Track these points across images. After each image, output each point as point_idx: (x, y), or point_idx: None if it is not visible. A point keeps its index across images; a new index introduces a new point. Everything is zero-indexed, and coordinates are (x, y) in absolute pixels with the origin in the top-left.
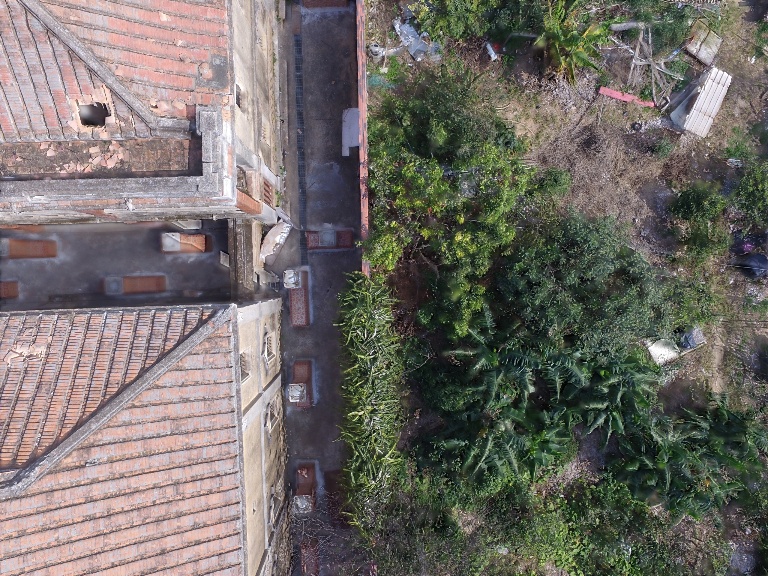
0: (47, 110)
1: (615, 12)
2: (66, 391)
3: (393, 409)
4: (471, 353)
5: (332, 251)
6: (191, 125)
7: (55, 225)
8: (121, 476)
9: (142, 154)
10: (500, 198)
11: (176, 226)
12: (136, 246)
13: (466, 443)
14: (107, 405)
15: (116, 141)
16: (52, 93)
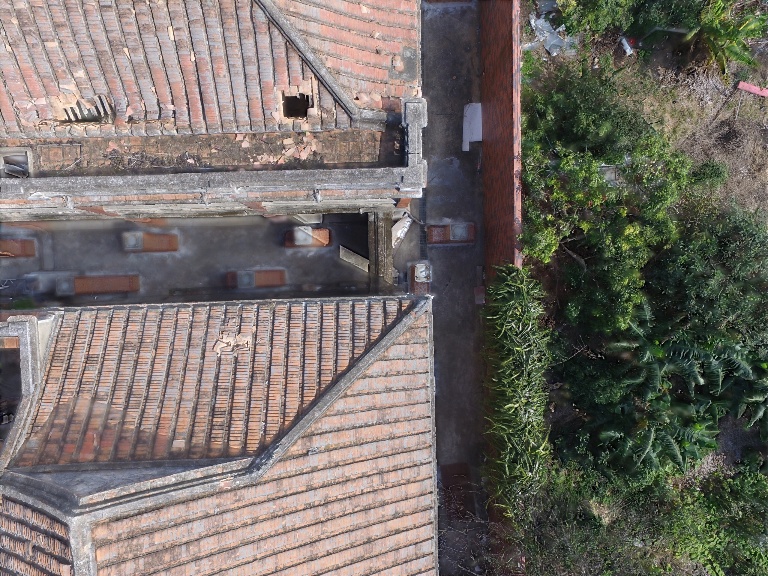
0: (253, 101)
1: (754, 7)
2: (281, 380)
3: (543, 402)
4: (634, 346)
5: (451, 246)
6: (388, 117)
7: (178, 219)
8: (336, 465)
9: (334, 146)
10: (666, 191)
11: (297, 220)
12: (256, 240)
13: (621, 435)
14: (327, 394)
15: (310, 133)
16: (261, 84)
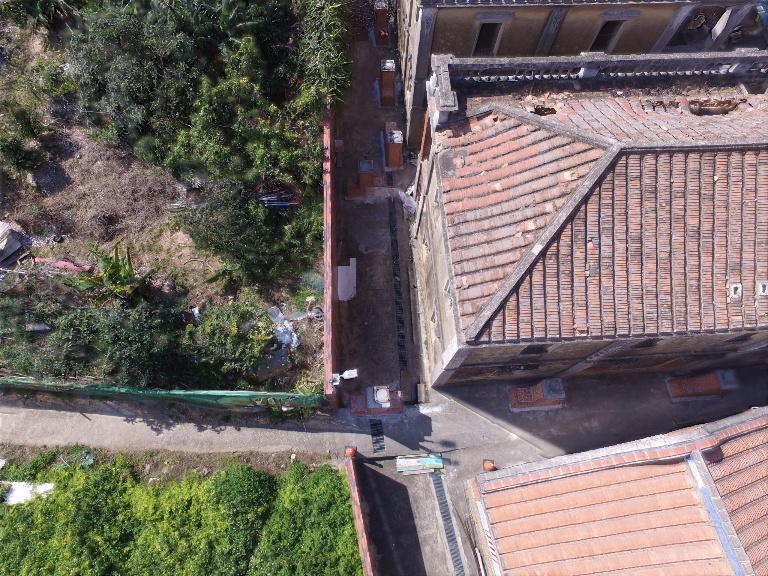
0: None
1: None
2: None
3: None
4: (241, 24)
5: None
6: (465, 114)
7: None
8: None
9: None
10: None
11: None
12: None
13: None
14: None
15: None
16: None
